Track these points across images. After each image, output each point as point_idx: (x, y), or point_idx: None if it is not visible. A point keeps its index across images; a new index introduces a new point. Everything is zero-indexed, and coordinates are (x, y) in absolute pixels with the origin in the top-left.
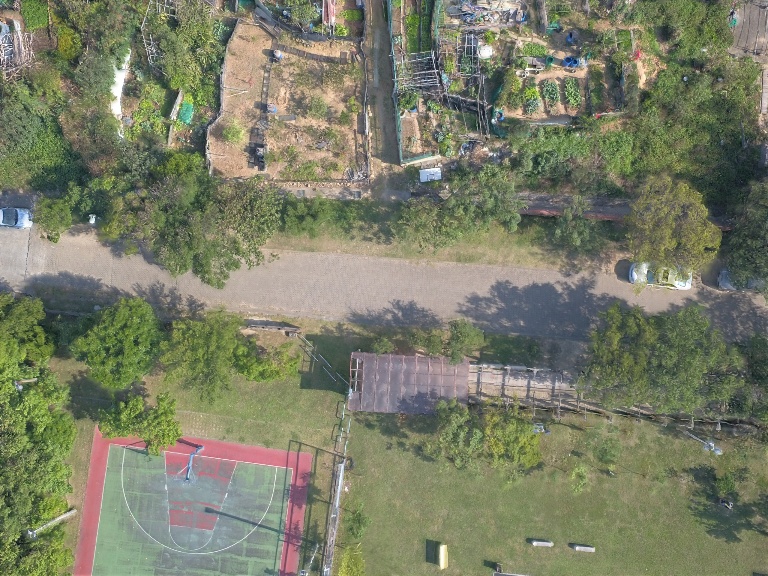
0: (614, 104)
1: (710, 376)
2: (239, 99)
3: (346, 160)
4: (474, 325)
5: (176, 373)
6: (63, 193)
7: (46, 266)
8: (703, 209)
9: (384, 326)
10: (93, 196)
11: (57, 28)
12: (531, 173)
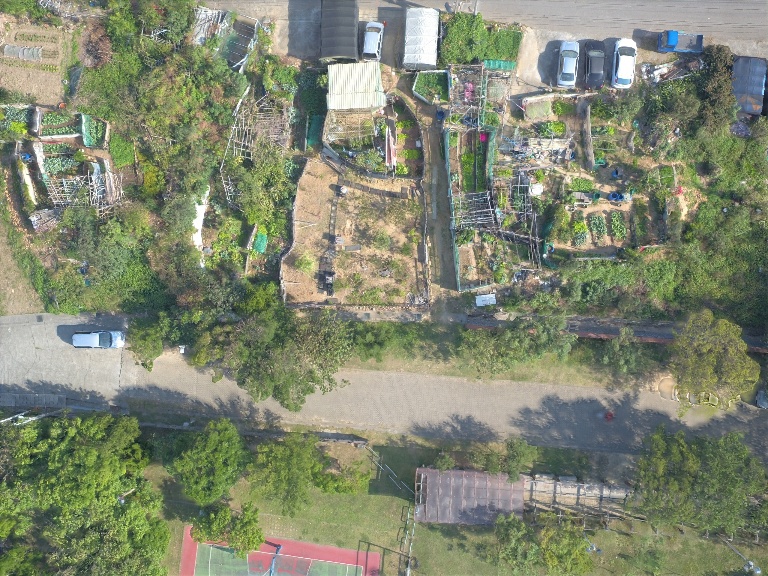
0: (658, 235)
1: (749, 498)
2: (309, 231)
3: (408, 286)
4: (527, 438)
5: (261, 491)
6: (155, 324)
7: (137, 382)
8: (742, 344)
9: (444, 439)
10: (182, 328)
11: (143, 167)
12: (580, 300)
